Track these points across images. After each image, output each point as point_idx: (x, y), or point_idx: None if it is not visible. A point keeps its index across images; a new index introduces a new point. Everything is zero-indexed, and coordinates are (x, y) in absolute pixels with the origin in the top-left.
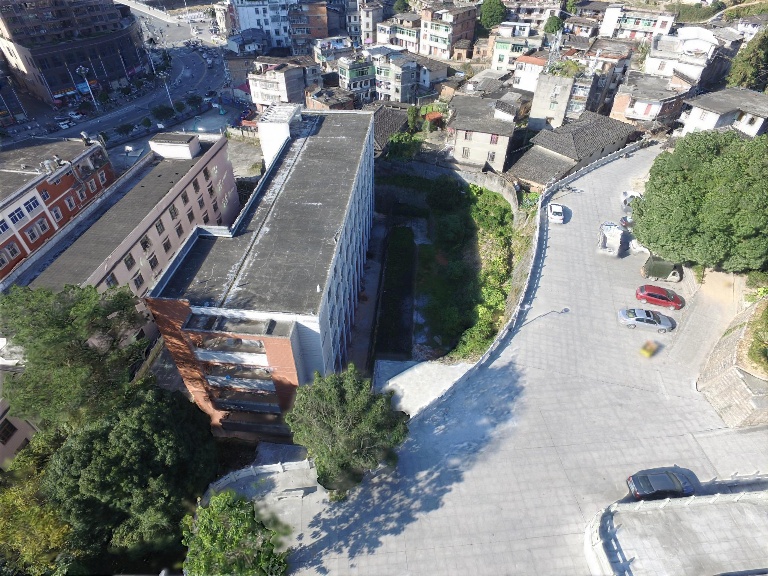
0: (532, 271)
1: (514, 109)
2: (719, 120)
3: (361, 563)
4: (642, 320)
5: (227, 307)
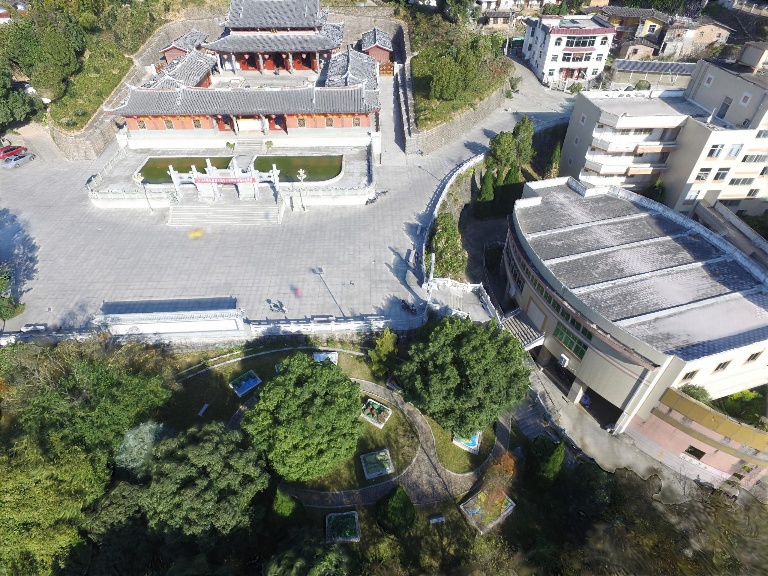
0: None
1: None
2: None
3: (39, 276)
4: (17, 159)
5: None
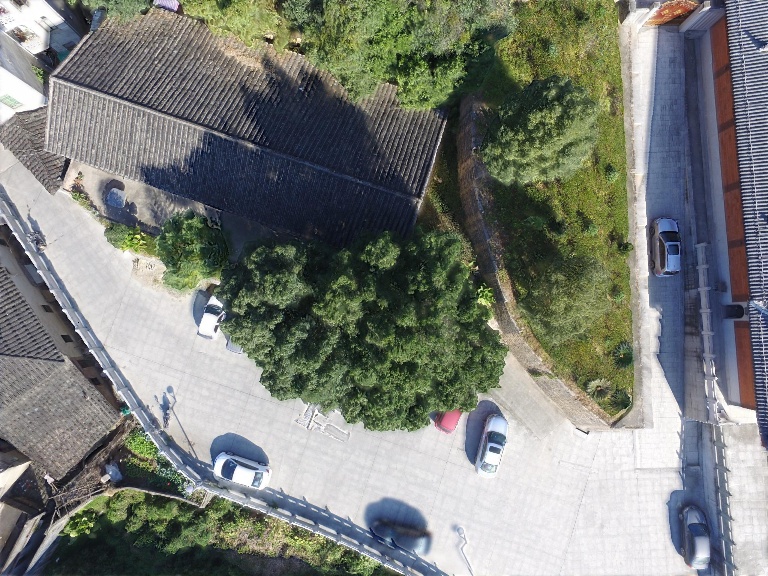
0: (382, 553)
1: None
2: (3, 64)
3: None
4: None
5: None
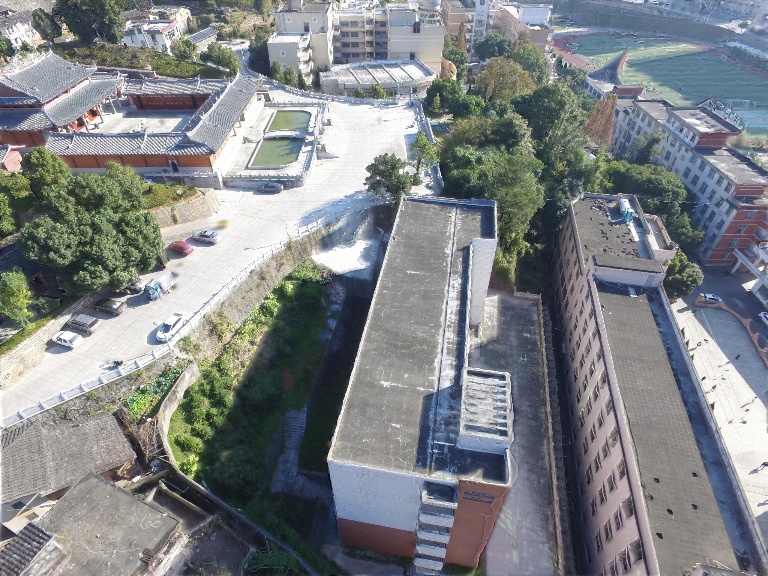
0: None
1: (0, 557)
2: None
3: None
4: None
5: (453, 207)
